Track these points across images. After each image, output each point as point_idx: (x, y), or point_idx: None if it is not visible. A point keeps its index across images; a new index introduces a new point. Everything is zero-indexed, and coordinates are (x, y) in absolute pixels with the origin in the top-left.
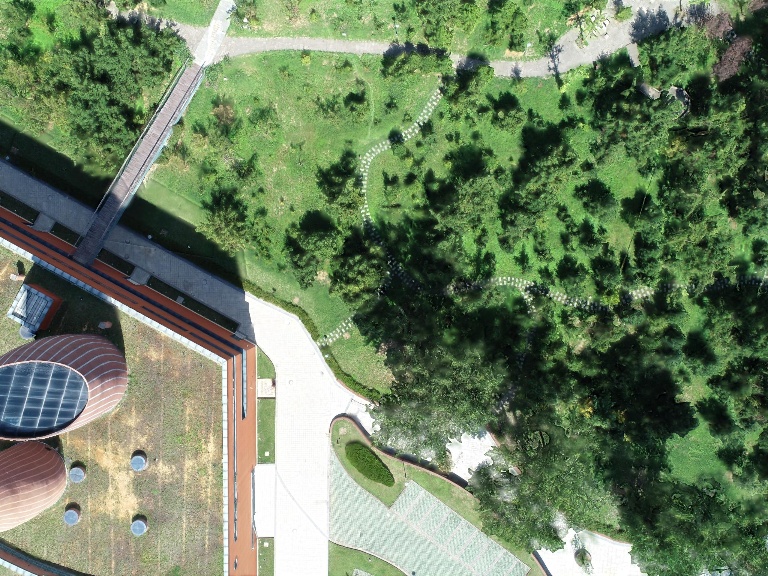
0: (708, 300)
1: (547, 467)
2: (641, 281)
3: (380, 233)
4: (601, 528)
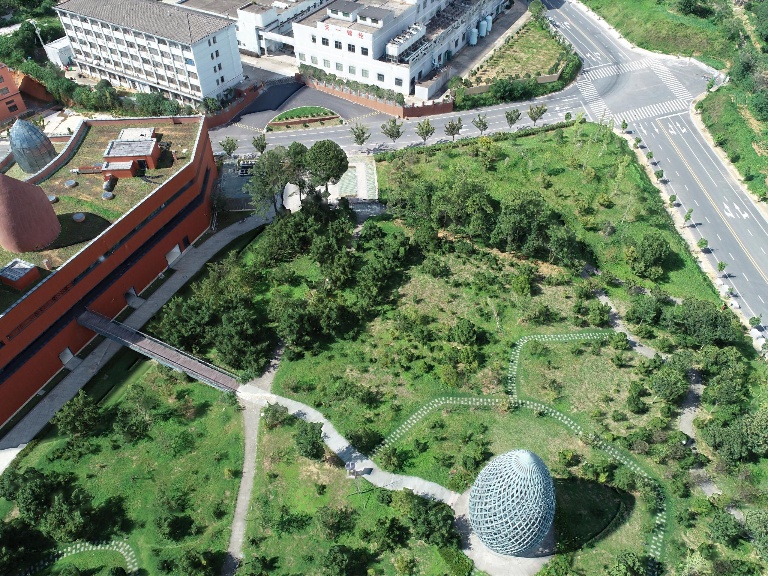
0: None
1: None
2: None
3: (40, 571)
4: None
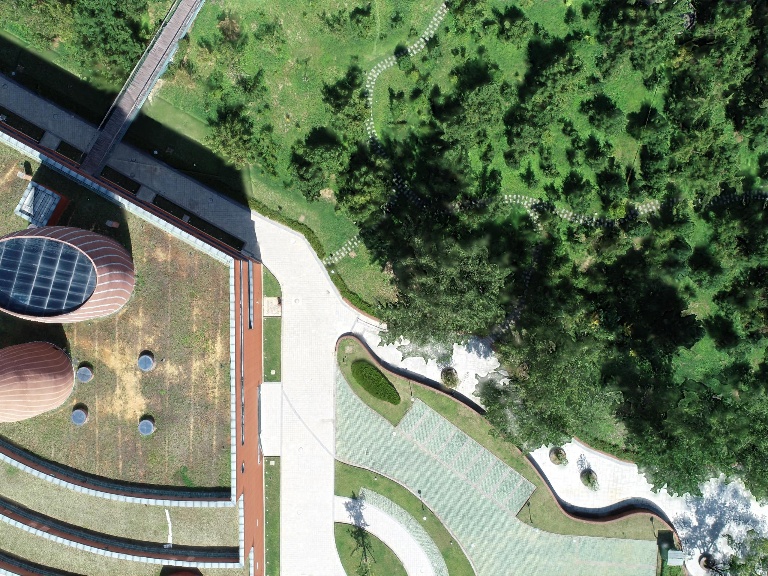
0: (714, 214)
1: (555, 359)
2: (647, 193)
3: (386, 150)
4: (607, 447)
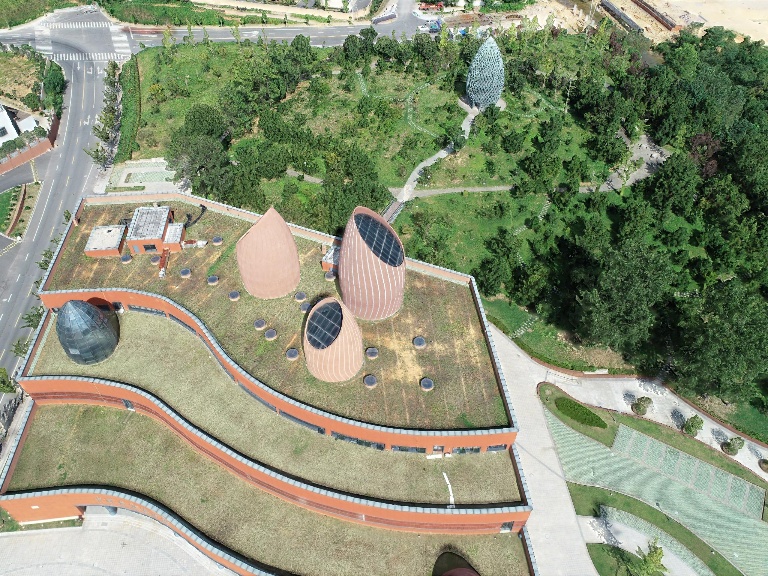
0: None
1: None
2: (725, 267)
3: None
4: None
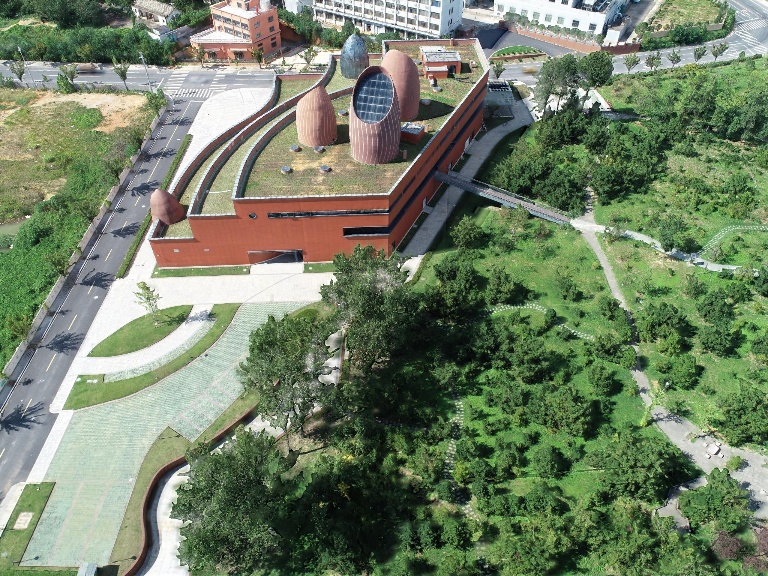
0: None
1: None
2: (482, 497)
3: None
4: None
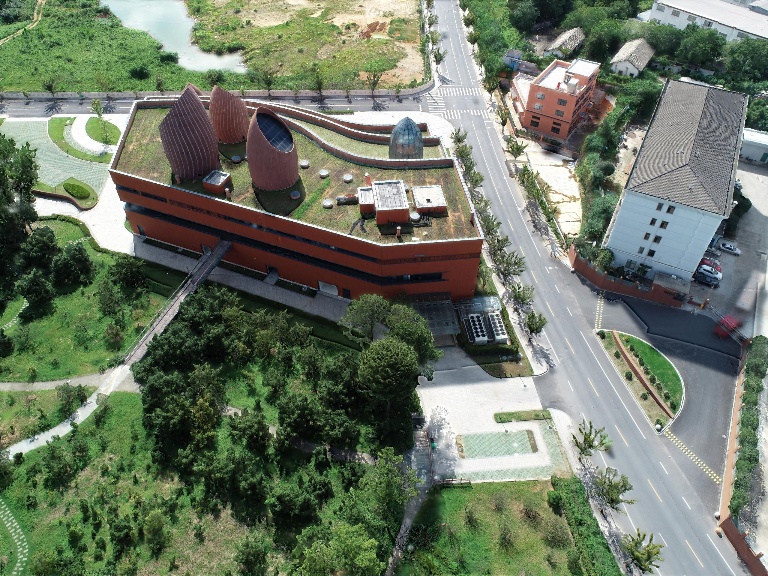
0: None
1: None
2: None
3: None
4: None
